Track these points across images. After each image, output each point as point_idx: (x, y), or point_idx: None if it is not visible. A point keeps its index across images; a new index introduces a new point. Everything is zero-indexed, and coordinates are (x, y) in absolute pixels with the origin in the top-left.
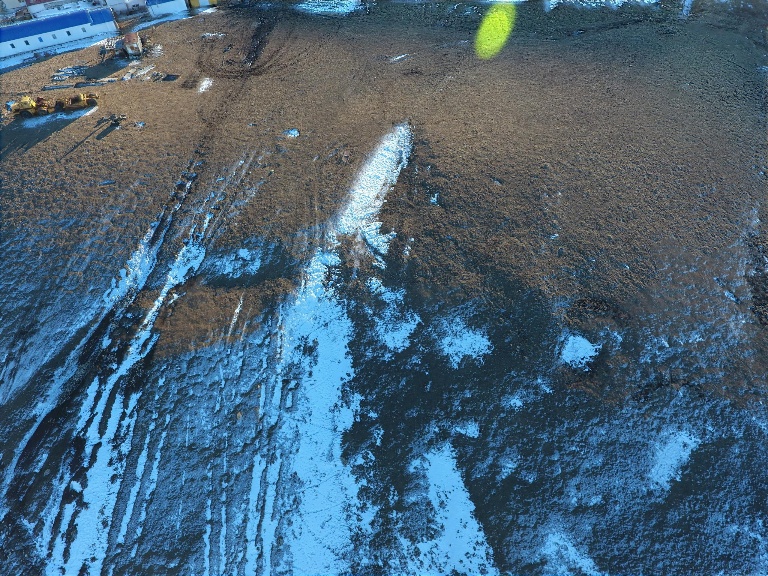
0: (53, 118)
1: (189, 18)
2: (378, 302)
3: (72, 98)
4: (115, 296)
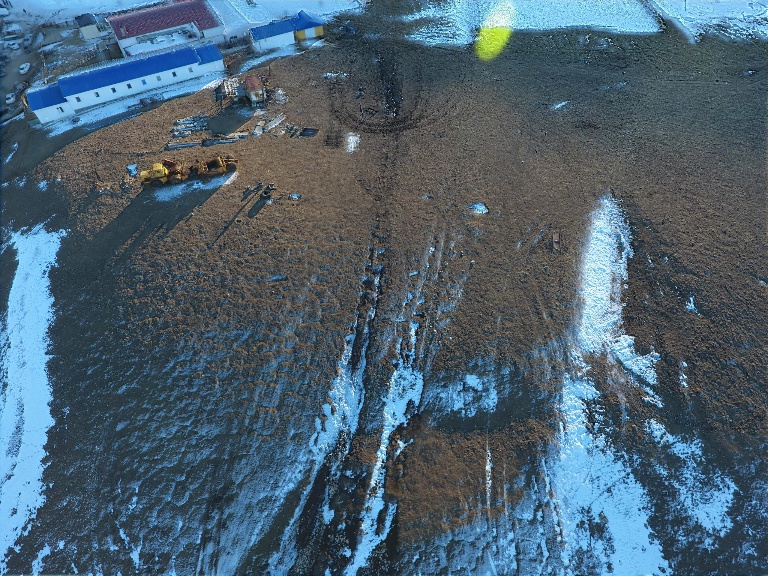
0: (189, 188)
1: (301, 54)
2: (670, 458)
3: (207, 162)
4: (324, 444)
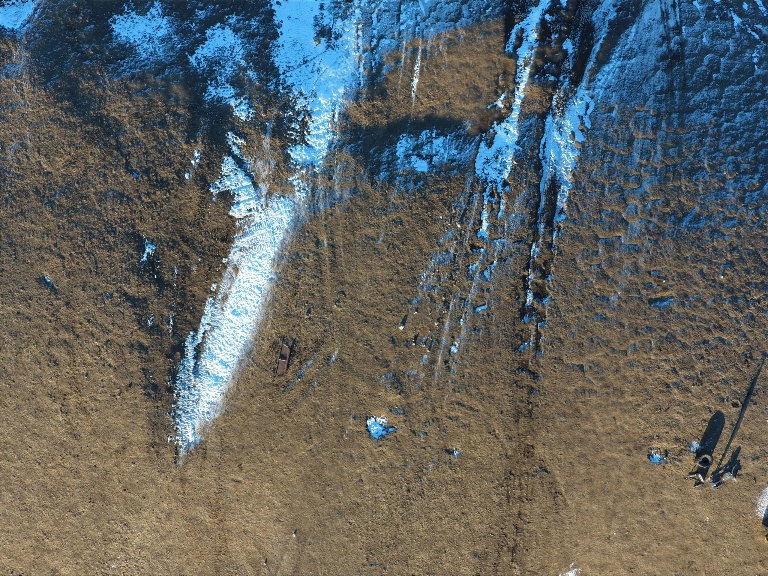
0: None
1: None
2: (240, 85)
3: None
4: (579, 104)
